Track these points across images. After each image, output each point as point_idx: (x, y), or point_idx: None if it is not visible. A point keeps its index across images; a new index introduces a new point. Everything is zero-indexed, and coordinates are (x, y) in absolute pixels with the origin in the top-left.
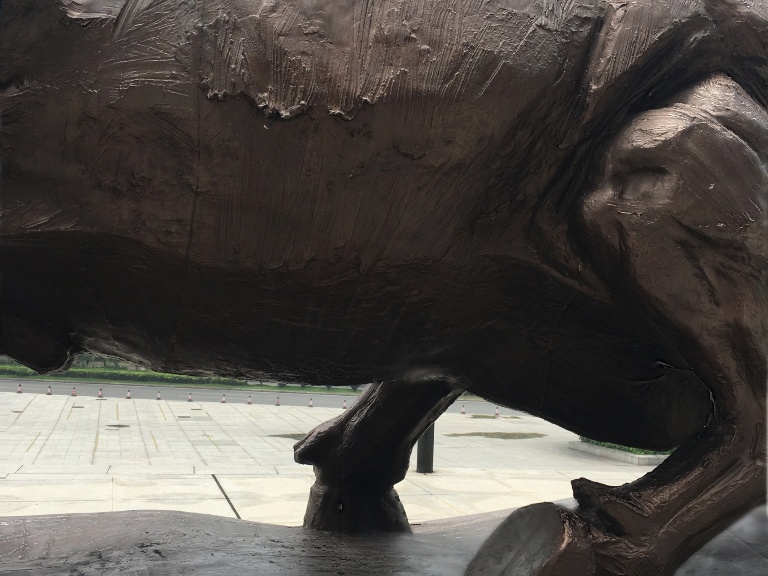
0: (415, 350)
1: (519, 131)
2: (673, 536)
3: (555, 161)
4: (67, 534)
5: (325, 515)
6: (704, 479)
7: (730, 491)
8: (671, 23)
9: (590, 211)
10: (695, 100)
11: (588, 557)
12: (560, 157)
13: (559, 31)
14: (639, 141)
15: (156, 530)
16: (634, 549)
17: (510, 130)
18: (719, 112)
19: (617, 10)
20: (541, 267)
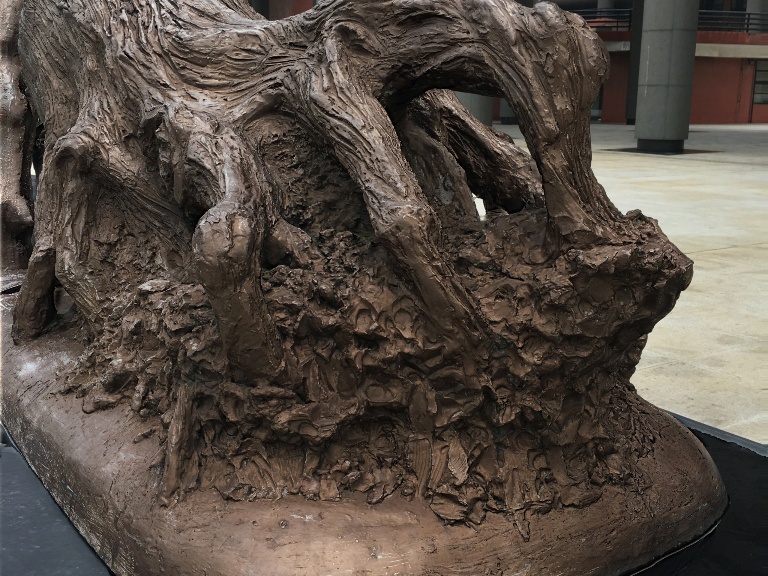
0: None
1: None
2: None
3: None
4: None
5: None
6: None
7: None
8: None
9: None
10: None
11: None
12: None
13: None
14: None
15: None
16: None
17: None
18: None
19: None
20: None
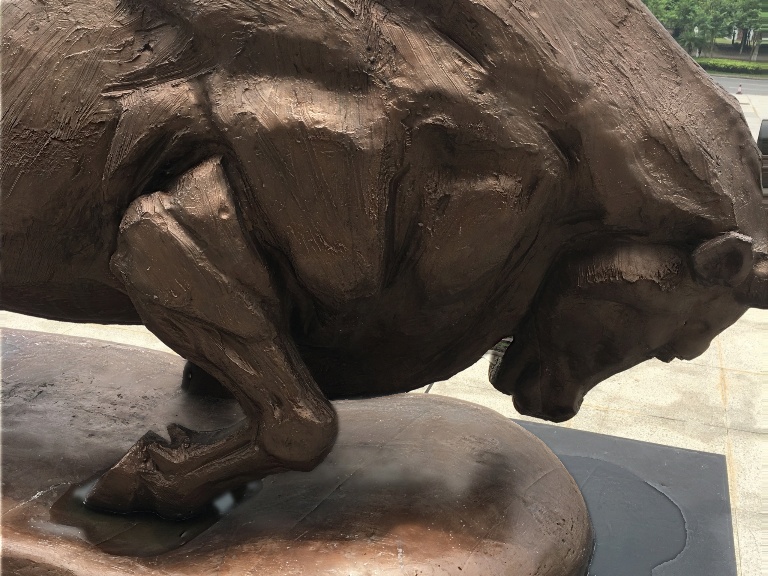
0: (97, 318)
1: (59, 209)
2: (196, 479)
3: (108, 221)
4: (42, 362)
5: (183, 379)
6: (224, 448)
7: (235, 462)
8: (148, 129)
9: (110, 266)
10: (175, 188)
11: (132, 478)
12: (108, 220)
13: (72, 139)
14: (121, 224)
15: (69, 373)
16: (162, 481)
17: (46, 212)
18: (173, 205)
19: (121, 115)
20: (117, 289)
